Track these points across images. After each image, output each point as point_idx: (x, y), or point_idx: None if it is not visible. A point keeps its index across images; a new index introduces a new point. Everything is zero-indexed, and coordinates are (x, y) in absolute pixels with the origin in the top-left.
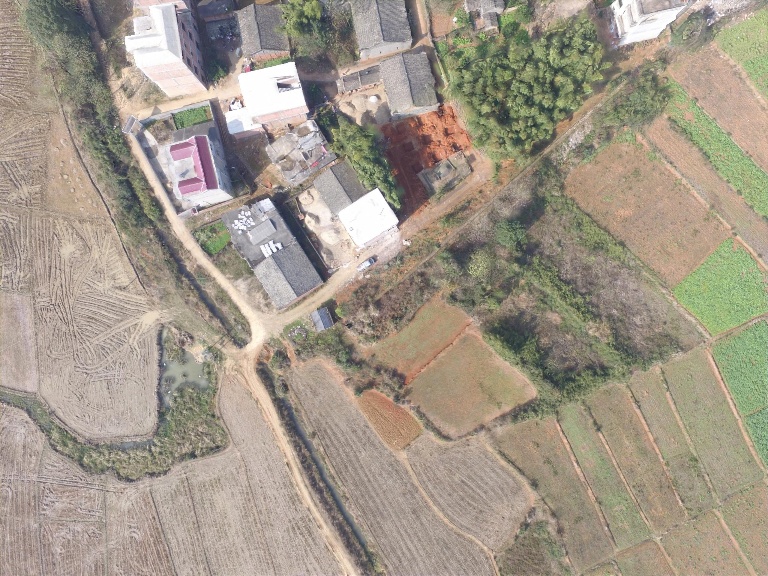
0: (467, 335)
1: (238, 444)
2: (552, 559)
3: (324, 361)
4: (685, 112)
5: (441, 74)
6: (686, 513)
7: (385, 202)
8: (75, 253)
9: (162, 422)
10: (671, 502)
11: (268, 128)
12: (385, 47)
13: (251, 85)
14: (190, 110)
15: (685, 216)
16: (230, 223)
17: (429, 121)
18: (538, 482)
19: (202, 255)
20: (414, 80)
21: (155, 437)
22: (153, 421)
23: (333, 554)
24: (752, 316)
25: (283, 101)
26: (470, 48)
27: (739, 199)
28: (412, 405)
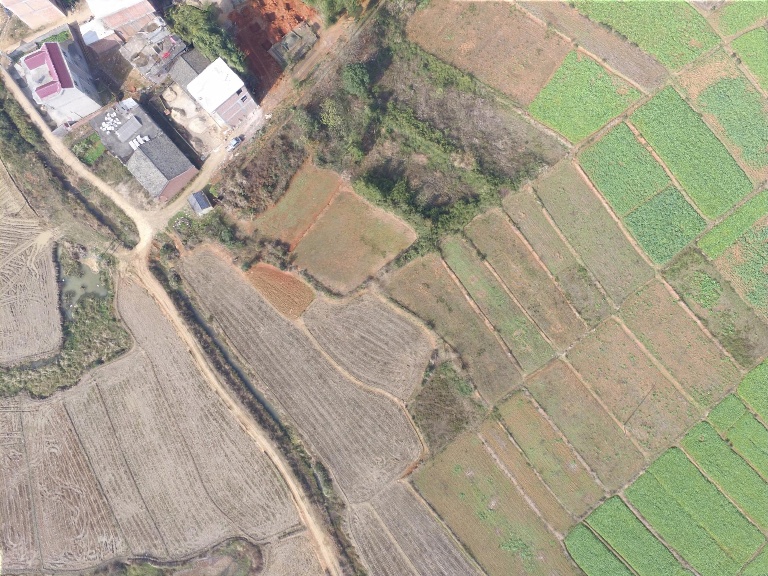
0: (342, 193)
1: (142, 342)
2: (463, 397)
3: (210, 245)
4: None
5: None
6: (585, 324)
7: (228, 68)
8: None
9: (67, 335)
10: (569, 317)
11: (124, 37)
12: None
13: None
14: (52, 37)
15: (526, 38)
16: (98, 127)
17: None
18: (435, 322)
19: (82, 168)
20: None
21: (62, 351)
22: (58, 336)
23: (248, 434)
24: (609, 118)
25: None
26: None
27: (573, 12)
28: (299, 270)
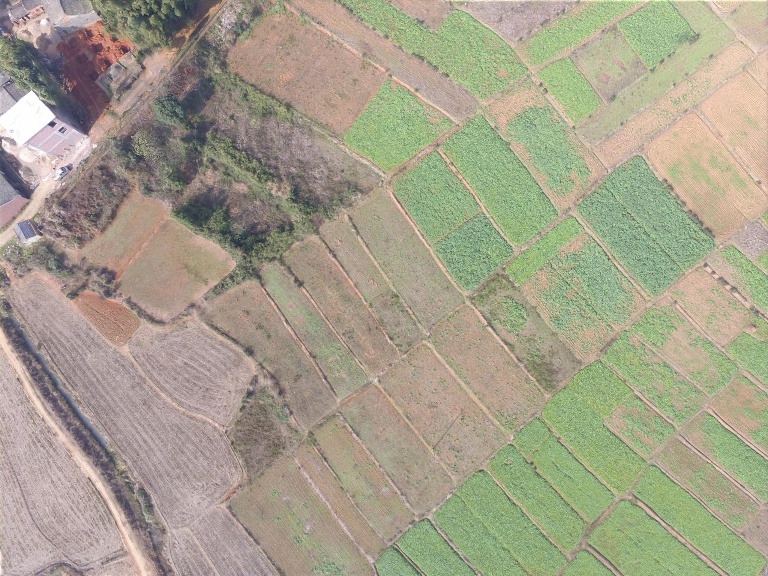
0: (167, 221)
1: None
2: (281, 423)
3: (39, 273)
4: None
5: None
6: (397, 350)
7: (39, 101)
8: None
9: None
10: (382, 342)
11: None
12: None
13: None
14: None
15: (342, 69)
16: None
17: (96, 31)
18: (254, 349)
19: None
20: None
21: None
22: None
23: (74, 460)
24: (420, 147)
25: None
26: None
27: (387, 43)
28: (124, 297)
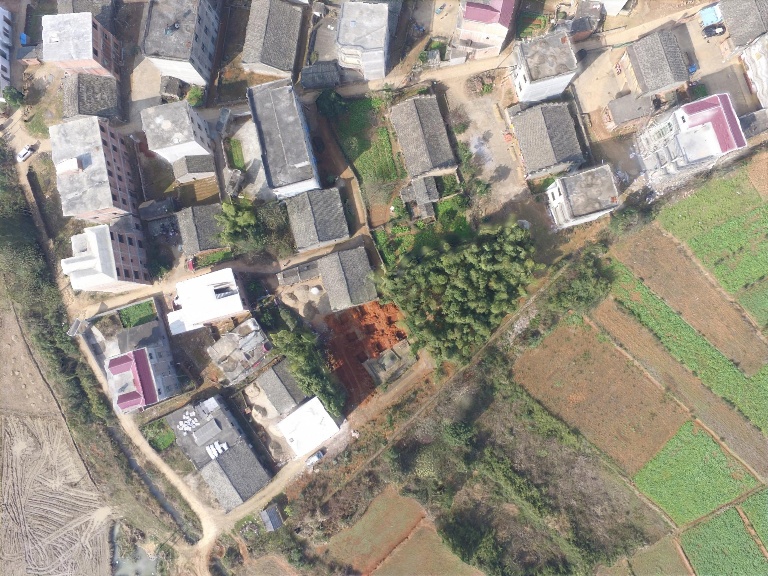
0: (423, 528)
1: None
2: None
3: (277, 558)
4: (631, 292)
5: (381, 263)
6: None
7: (325, 411)
8: (27, 450)
9: None
10: None
11: (212, 323)
12: (322, 243)
13: (189, 292)
14: (135, 306)
15: (640, 399)
16: (175, 424)
17: (371, 311)
18: None
19: (151, 450)
20: (351, 277)
21: None
22: None
23: None
24: (720, 504)
25: (221, 308)
26: (408, 236)
27: (695, 380)
28: None
